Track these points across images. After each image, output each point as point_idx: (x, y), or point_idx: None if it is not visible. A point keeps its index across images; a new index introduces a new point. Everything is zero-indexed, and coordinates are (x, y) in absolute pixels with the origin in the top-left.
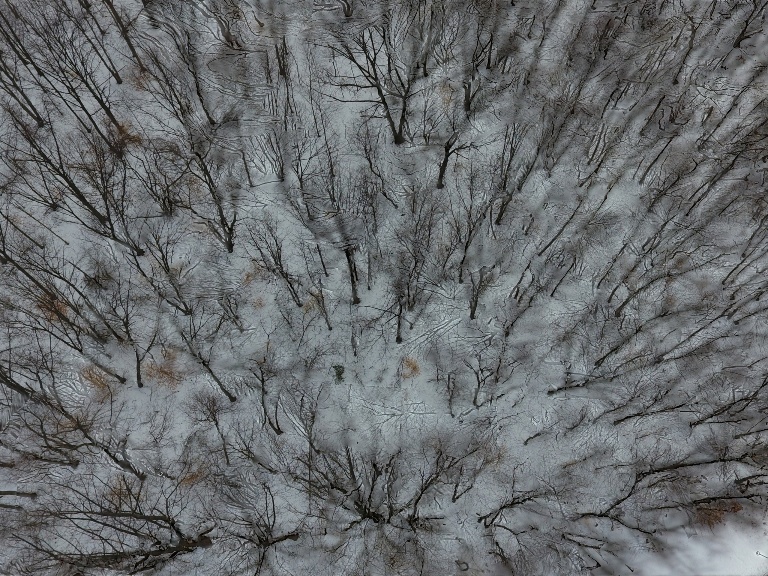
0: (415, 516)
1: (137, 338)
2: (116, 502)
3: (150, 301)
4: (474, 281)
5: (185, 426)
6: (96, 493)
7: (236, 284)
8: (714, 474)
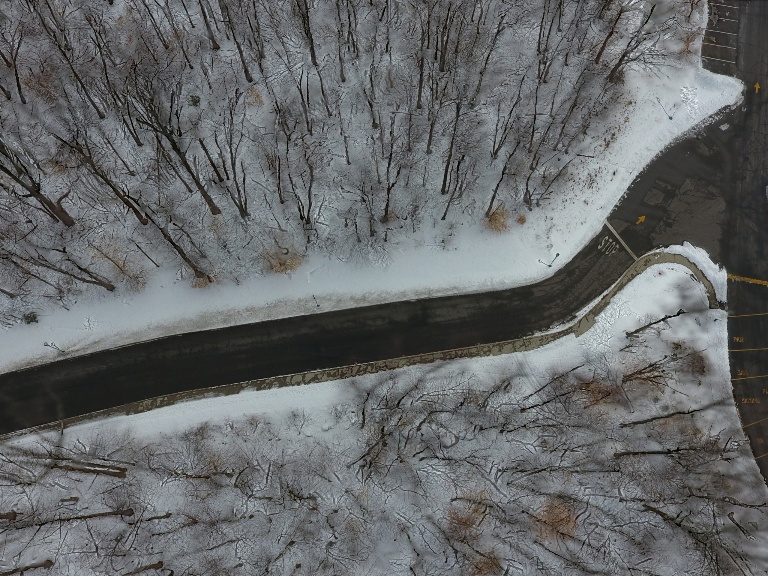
0: (242, 201)
1: (22, 60)
2: None
3: (35, 32)
4: (301, 8)
5: (60, 135)
6: None
7: (108, 19)
8: (507, 195)
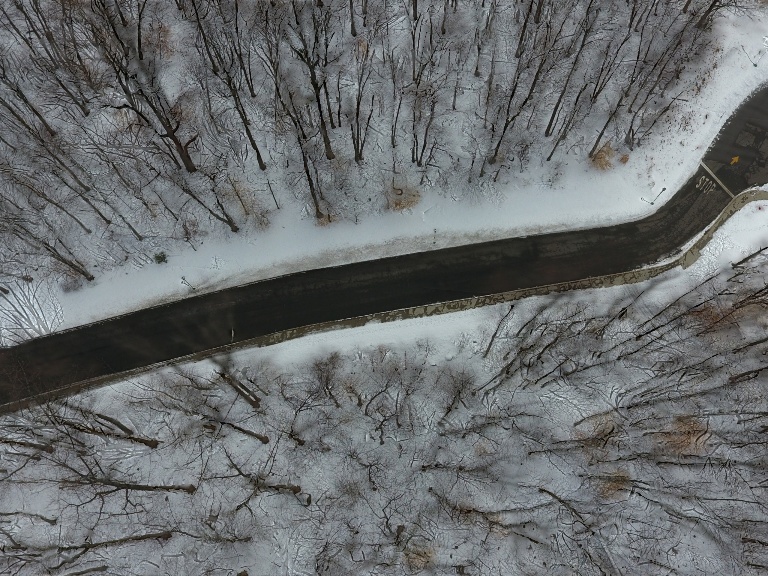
0: (359, 143)
1: None
2: (119, 138)
3: None
4: None
5: (176, 88)
6: (103, 130)
7: None
8: None
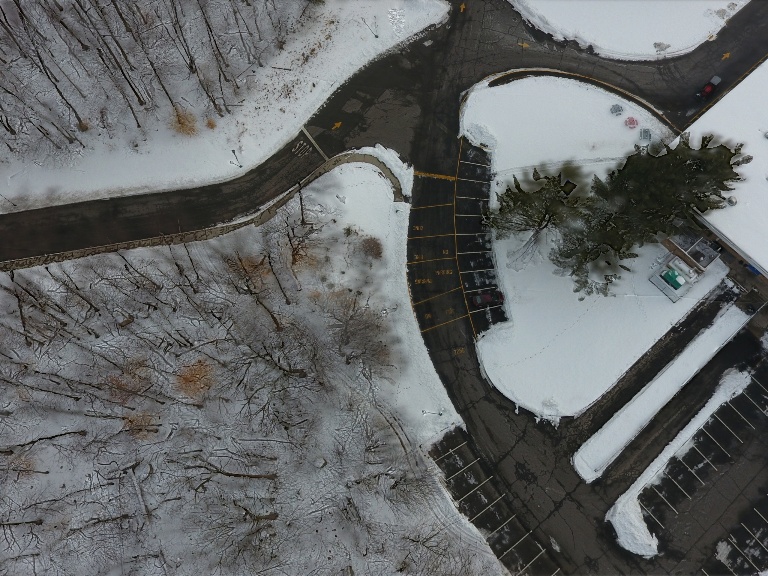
0: None
1: None
2: None
3: None
4: None
5: None
6: None
7: None
8: (201, 103)
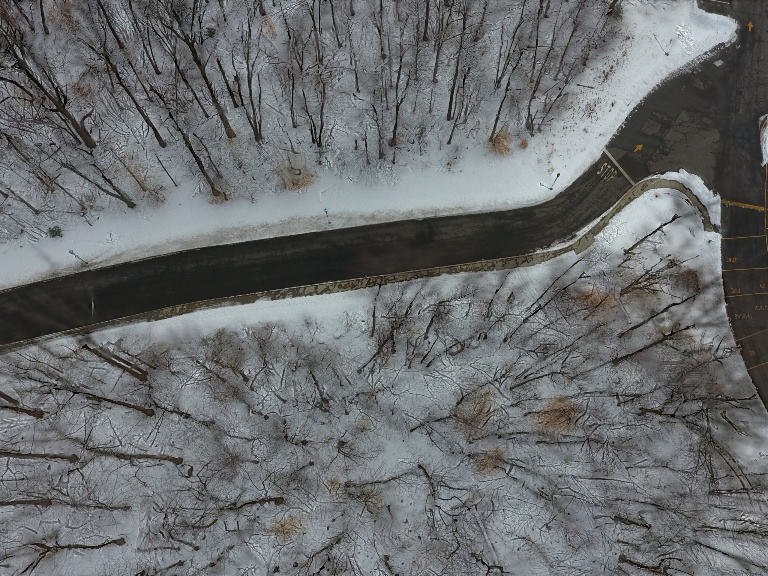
0: (257, 122)
1: None
2: (21, 112)
3: None
4: None
5: (81, 64)
6: (5, 104)
7: None
8: None
